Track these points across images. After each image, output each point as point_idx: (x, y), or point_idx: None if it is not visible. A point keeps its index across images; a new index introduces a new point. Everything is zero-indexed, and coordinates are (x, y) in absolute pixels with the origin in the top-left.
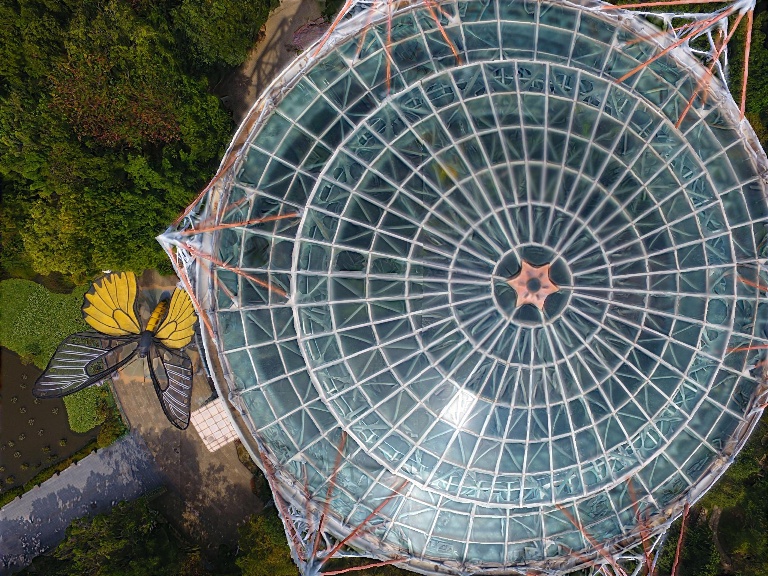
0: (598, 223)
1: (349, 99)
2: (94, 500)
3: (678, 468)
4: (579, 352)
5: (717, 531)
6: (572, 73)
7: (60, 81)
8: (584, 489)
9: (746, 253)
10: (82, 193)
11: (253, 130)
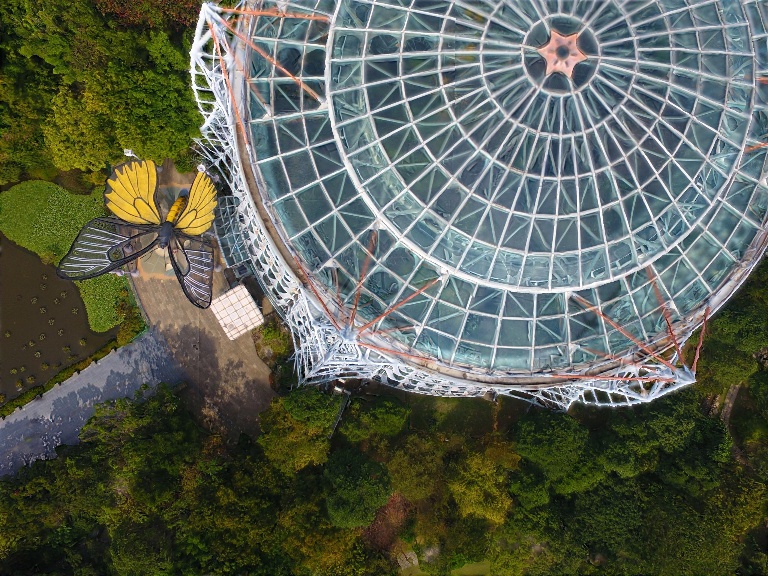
0: None
1: None
2: (114, 399)
3: (699, 274)
4: (606, 122)
5: (728, 424)
6: None
7: None
8: (611, 273)
9: (761, 66)
10: (105, 69)
11: None
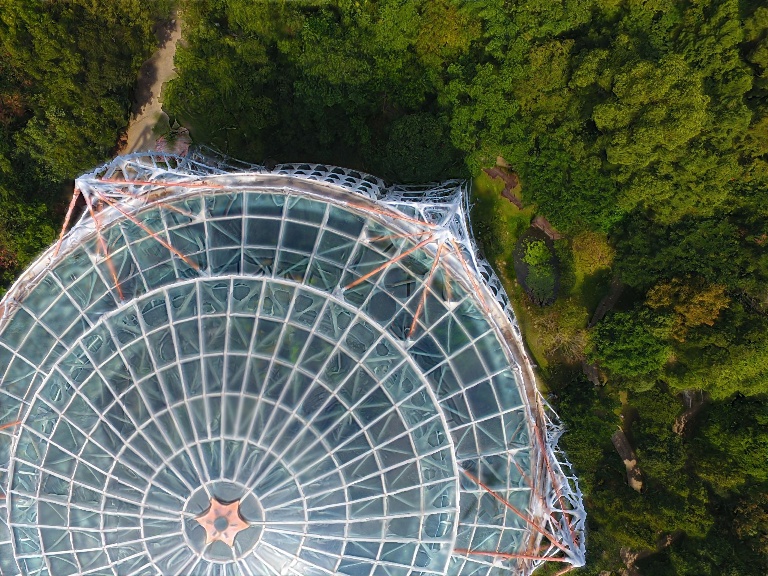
0: (294, 455)
1: (93, 296)
2: None
3: None
4: None
5: None
6: (290, 289)
7: None
8: None
9: (498, 443)
10: None
11: None
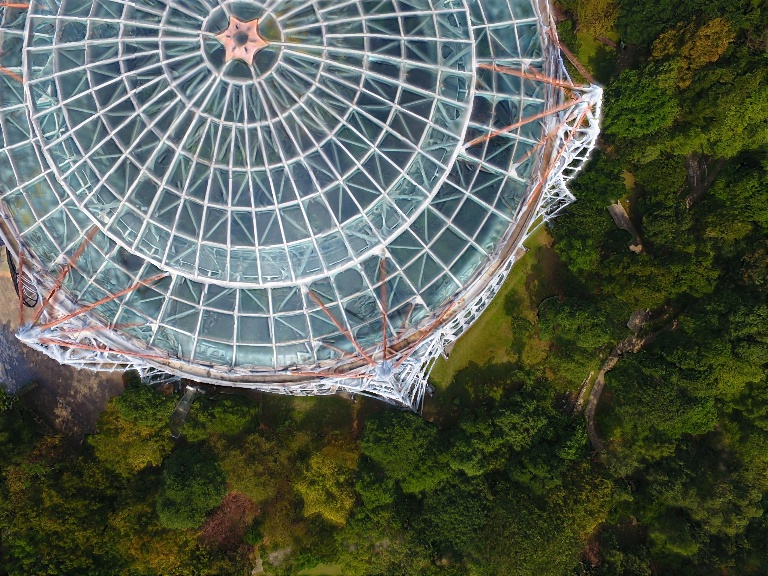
0: None
1: None
2: None
3: (446, 268)
4: (294, 111)
5: (593, 421)
6: None
7: None
8: (324, 267)
9: (511, 54)
10: None
11: None
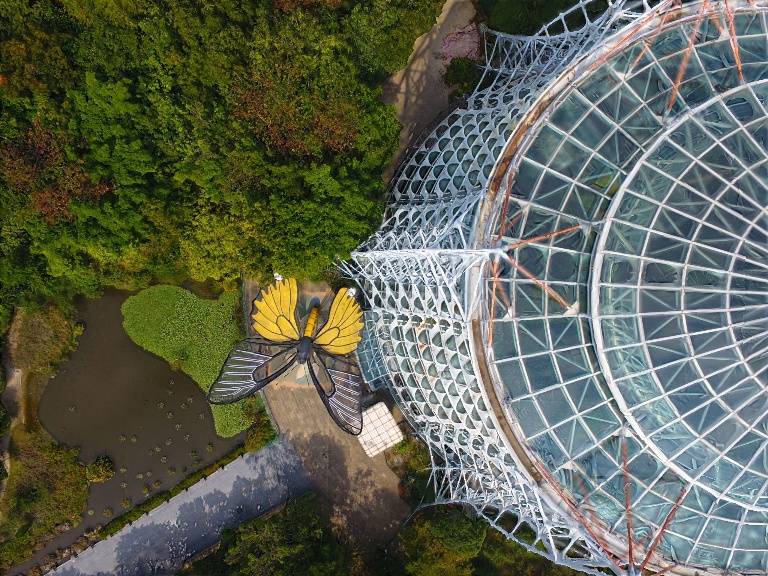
0: None
1: (621, 112)
2: (240, 504)
3: None
4: None
5: None
6: None
7: (242, 90)
8: None
9: None
10: (267, 201)
11: (525, 142)
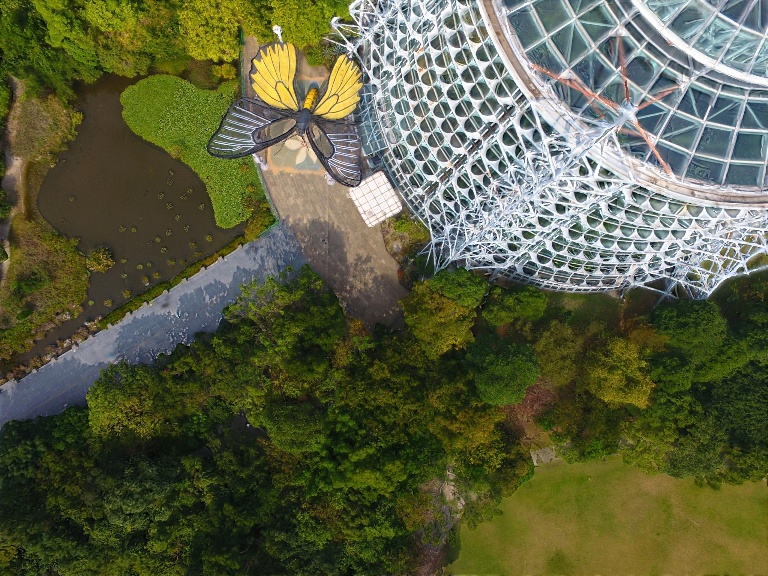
0: None
1: None
2: (240, 295)
3: None
4: None
5: None
6: None
7: None
8: None
9: None
10: None
11: None
